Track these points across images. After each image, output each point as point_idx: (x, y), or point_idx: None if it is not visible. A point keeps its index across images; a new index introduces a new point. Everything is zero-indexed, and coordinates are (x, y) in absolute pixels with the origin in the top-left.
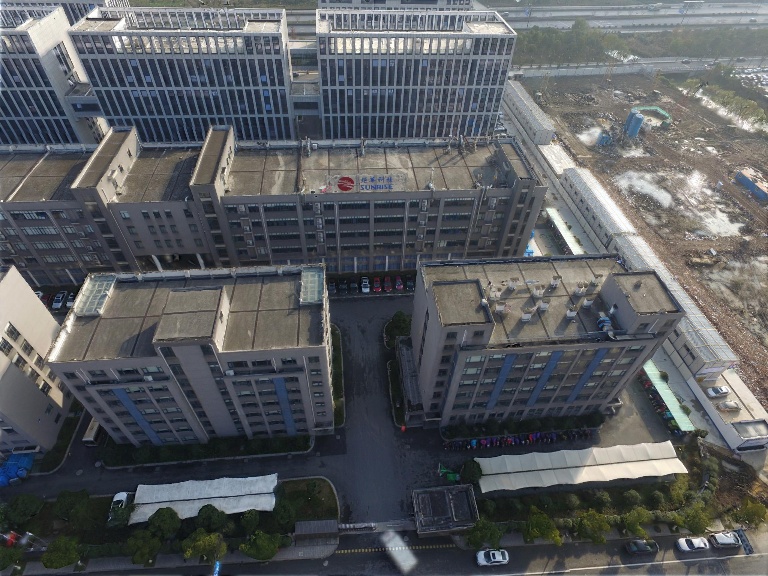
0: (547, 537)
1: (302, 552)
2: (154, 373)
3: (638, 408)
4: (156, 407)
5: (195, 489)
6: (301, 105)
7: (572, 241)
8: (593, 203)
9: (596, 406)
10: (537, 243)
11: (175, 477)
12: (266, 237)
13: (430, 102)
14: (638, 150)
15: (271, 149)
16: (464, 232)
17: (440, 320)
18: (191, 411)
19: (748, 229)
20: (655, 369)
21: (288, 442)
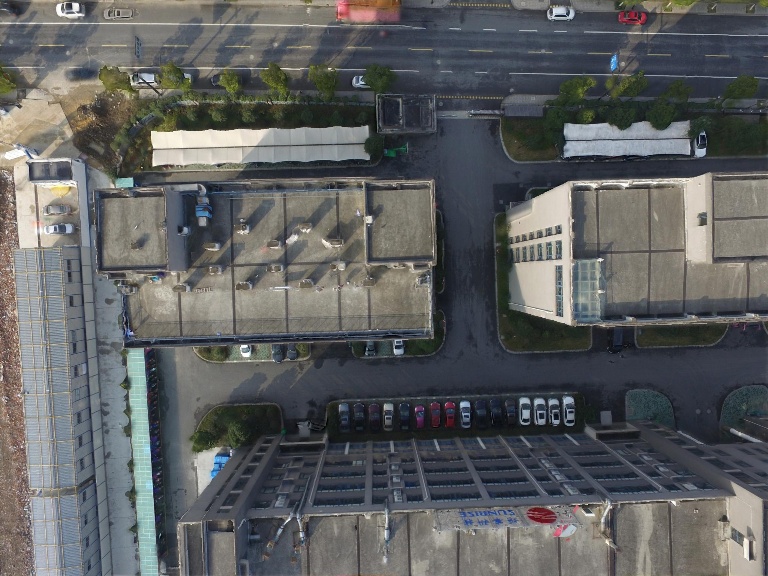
0: (324, 65)
1: (532, 100)
2: None
3: None
4: None
5: (638, 148)
6: None
7: (143, 494)
8: (76, 575)
9: None
10: None
11: (655, 171)
12: (628, 462)
13: None
14: None
15: None
16: (327, 475)
17: None
18: None
19: None
20: None
21: None
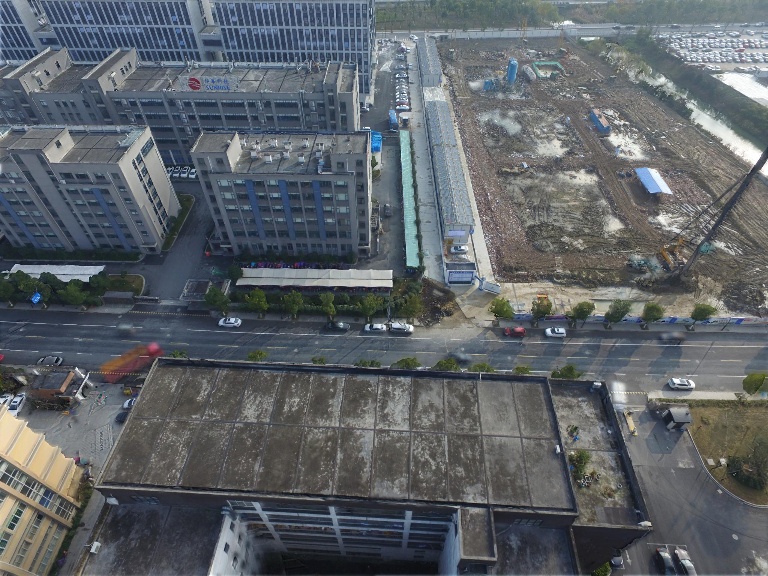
0: (253, 300)
1: (107, 309)
2: (16, 178)
3: (391, 256)
4: (24, 209)
5: (49, 269)
6: (209, 42)
7: (407, 152)
8: (434, 124)
9: (349, 247)
10: (382, 155)
11: None
12: None
13: (309, 41)
14: (517, 94)
15: (165, 68)
16: None
17: (191, 149)
18: (51, 218)
19: (570, 151)
20: (415, 232)
21: (125, 255)
